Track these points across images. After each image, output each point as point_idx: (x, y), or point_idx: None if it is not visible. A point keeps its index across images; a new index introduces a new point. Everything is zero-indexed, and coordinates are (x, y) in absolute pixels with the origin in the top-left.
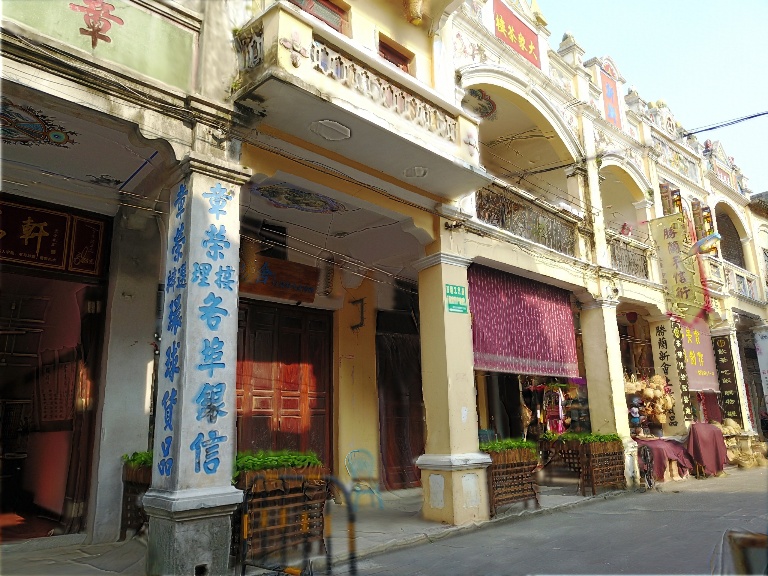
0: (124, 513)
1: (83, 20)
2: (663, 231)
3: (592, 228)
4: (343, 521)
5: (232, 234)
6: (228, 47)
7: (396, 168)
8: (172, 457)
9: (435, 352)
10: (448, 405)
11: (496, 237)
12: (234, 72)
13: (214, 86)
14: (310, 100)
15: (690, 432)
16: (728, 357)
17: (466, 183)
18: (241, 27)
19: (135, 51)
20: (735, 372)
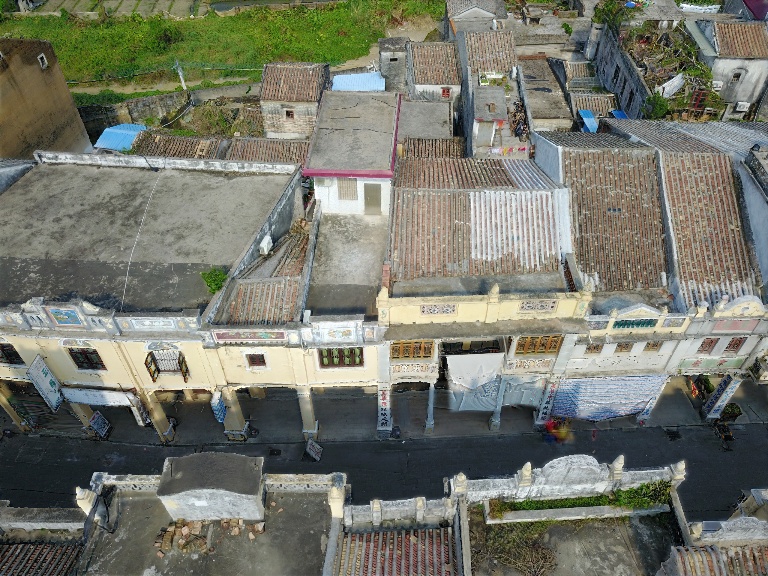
0: (697, 379)
1: (719, 363)
2: None
3: None
4: (752, 396)
5: (737, 386)
6: None
7: None
8: (709, 409)
9: None
10: None
11: None
12: (753, 363)
13: (745, 367)
14: None
15: None
16: None
17: None
18: (759, 356)
19: (728, 364)
20: None
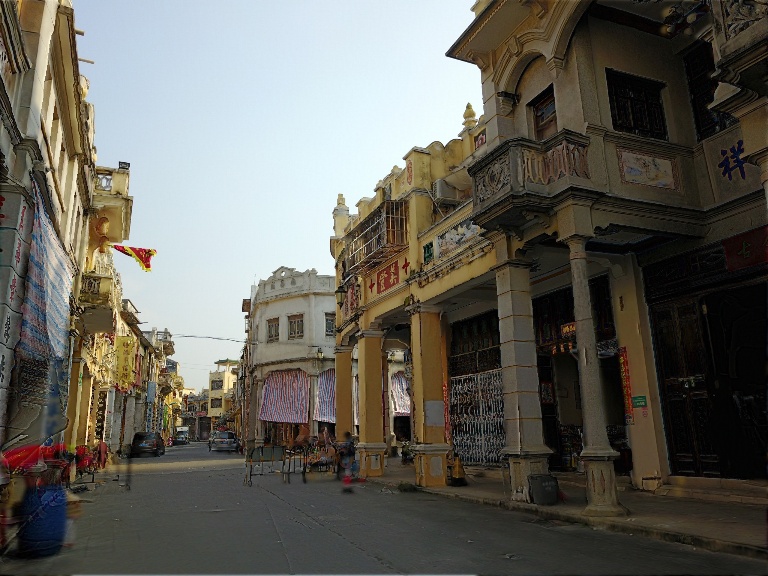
0: None
1: None
2: (123, 343)
3: (95, 335)
4: None
5: None
6: (80, 280)
7: (90, 323)
8: (54, 446)
9: (68, 403)
10: (73, 428)
11: (86, 347)
12: None
13: None
14: (110, 314)
15: (98, 445)
16: (103, 404)
17: (104, 330)
18: None
19: None
20: (105, 413)
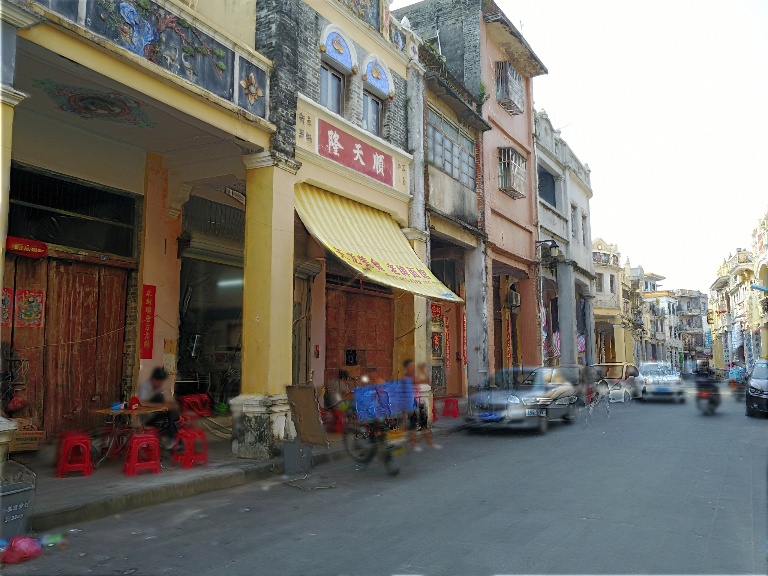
0: None
1: None
2: None
3: None
4: None
5: None
6: None
7: None
8: None
9: None
10: None
11: None
12: None
13: None
14: None
15: None
16: None
17: None
18: None
19: None
20: None
